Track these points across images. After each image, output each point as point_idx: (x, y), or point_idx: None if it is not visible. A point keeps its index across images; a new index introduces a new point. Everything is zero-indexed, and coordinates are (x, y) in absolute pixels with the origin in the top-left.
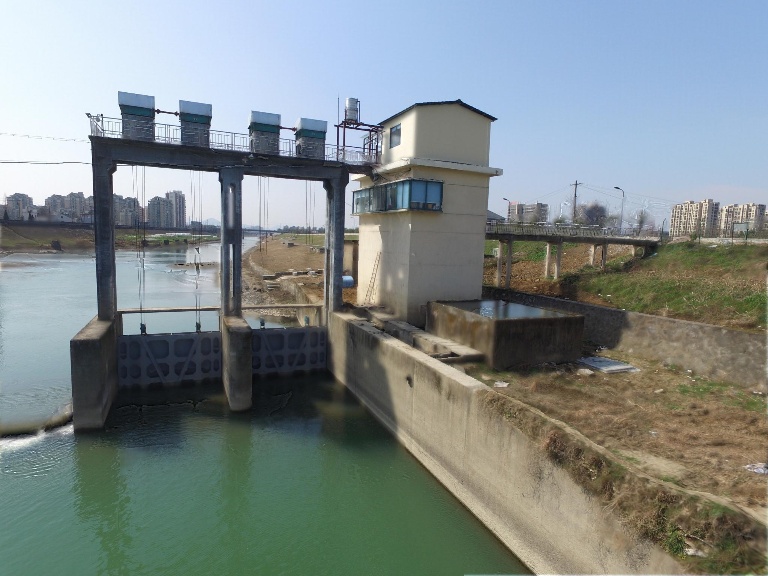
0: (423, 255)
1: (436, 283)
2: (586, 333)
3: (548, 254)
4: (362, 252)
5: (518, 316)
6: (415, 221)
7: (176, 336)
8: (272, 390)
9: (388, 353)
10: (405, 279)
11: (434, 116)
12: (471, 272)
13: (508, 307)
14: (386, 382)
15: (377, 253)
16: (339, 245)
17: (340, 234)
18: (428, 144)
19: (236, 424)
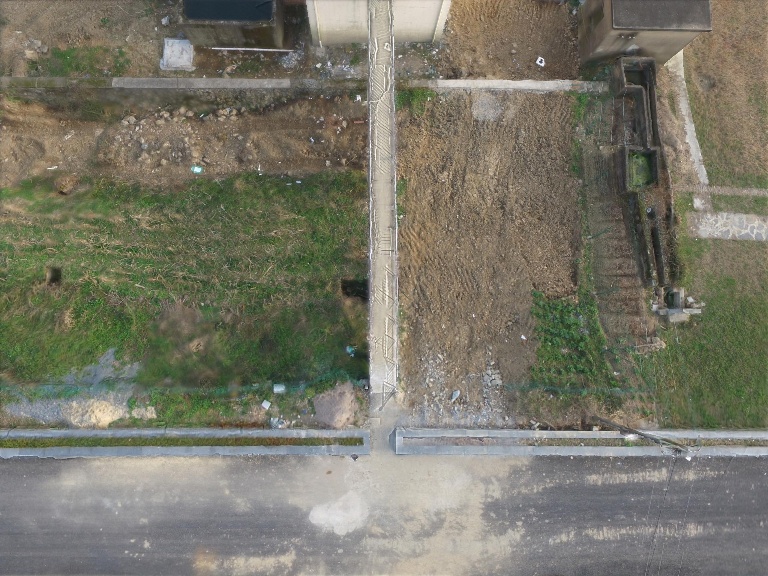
0: None
1: None
2: None
3: None
4: None
5: None
6: None
7: None
8: None
9: None
10: None
11: None
12: None
13: None
14: None
15: None
16: None
17: None
18: None
19: None
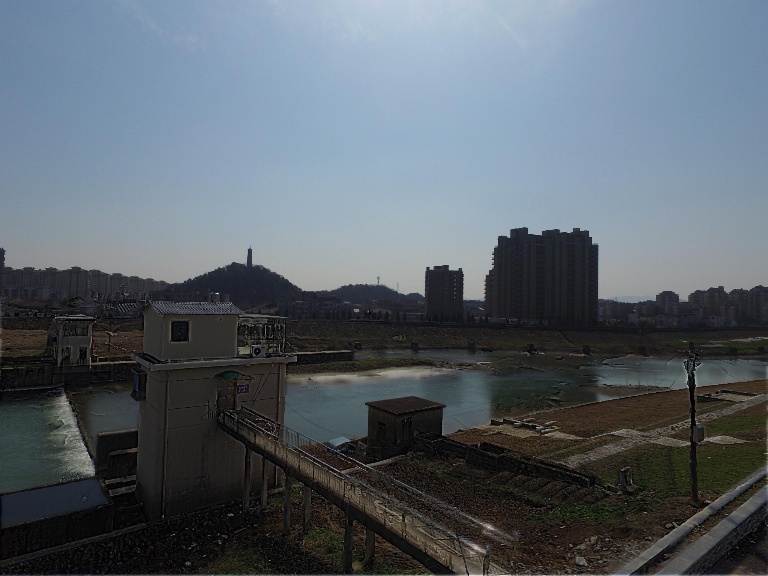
0: None
1: None
2: None
3: None
4: None
5: None
6: None
7: None
8: None
9: None
10: None
11: None
12: None
13: None
14: None
15: None
16: None
17: None
18: None
19: None
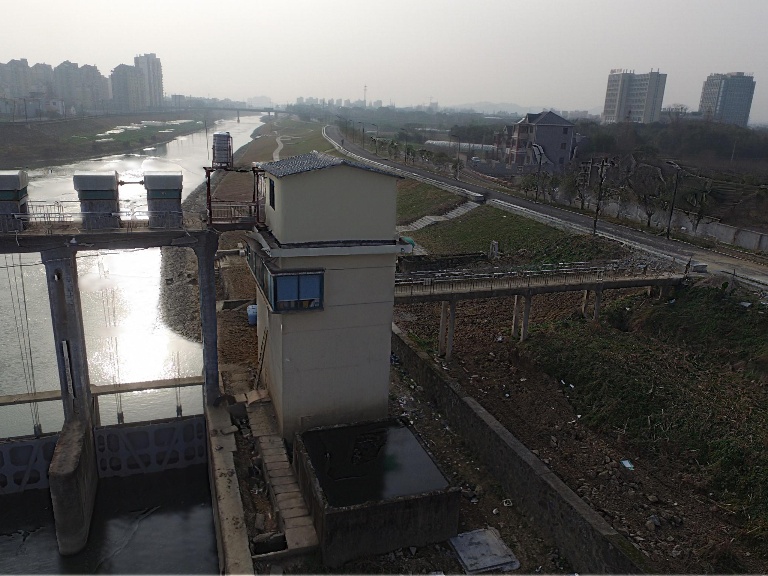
0: (302, 359)
1: (322, 390)
2: (498, 473)
3: (516, 306)
4: (259, 312)
5: (408, 453)
6: (288, 321)
7: (11, 444)
8: (137, 494)
9: (219, 521)
10: (280, 387)
11: (309, 185)
12: (372, 371)
13: (404, 432)
14: (220, 550)
15: (265, 330)
16: (210, 327)
17: (210, 314)
18: (302, 222)
19: (67, 568)
